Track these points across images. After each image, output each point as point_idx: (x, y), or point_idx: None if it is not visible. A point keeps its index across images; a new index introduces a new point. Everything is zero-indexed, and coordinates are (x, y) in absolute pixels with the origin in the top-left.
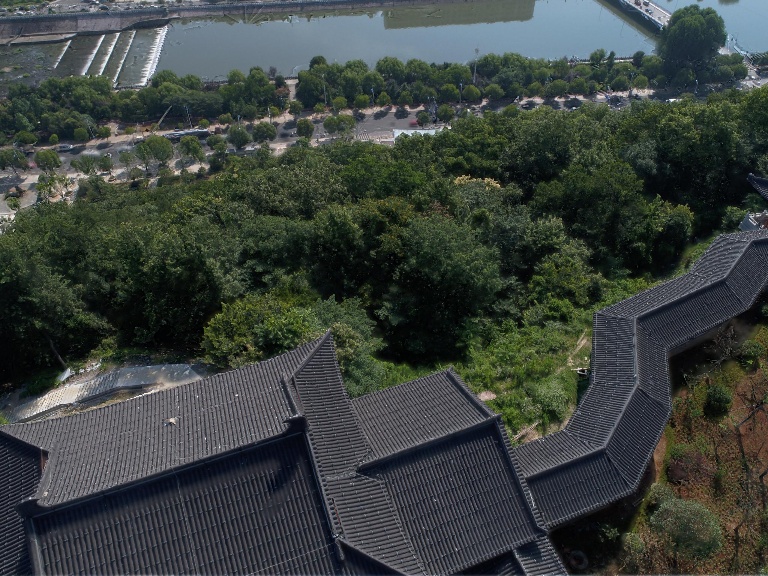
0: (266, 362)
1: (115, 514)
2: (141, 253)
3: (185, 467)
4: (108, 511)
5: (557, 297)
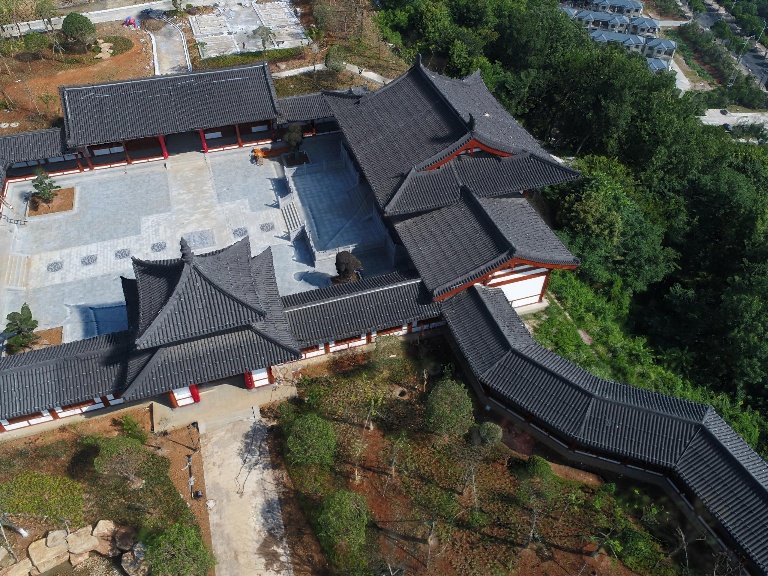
0: (547, 154)
1: (421, 91)
2: (650, 114)
3: (444, 98)
4: (422, 88)
5: (766, 435)
